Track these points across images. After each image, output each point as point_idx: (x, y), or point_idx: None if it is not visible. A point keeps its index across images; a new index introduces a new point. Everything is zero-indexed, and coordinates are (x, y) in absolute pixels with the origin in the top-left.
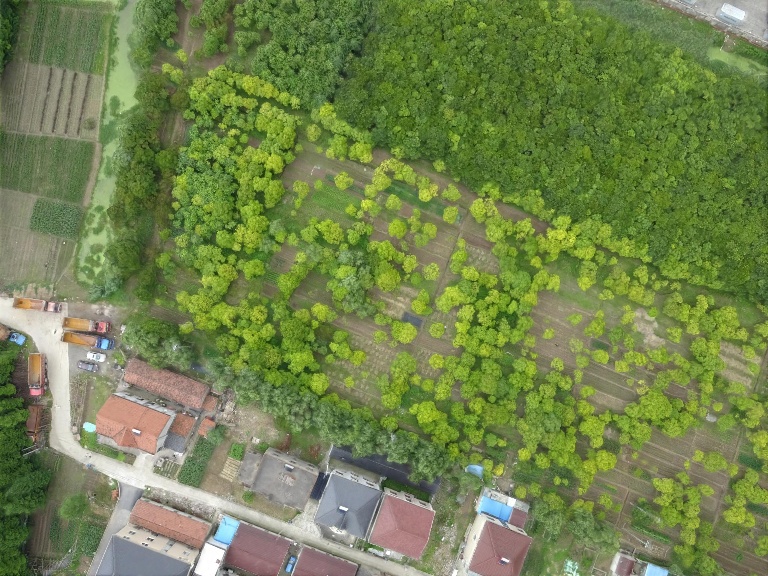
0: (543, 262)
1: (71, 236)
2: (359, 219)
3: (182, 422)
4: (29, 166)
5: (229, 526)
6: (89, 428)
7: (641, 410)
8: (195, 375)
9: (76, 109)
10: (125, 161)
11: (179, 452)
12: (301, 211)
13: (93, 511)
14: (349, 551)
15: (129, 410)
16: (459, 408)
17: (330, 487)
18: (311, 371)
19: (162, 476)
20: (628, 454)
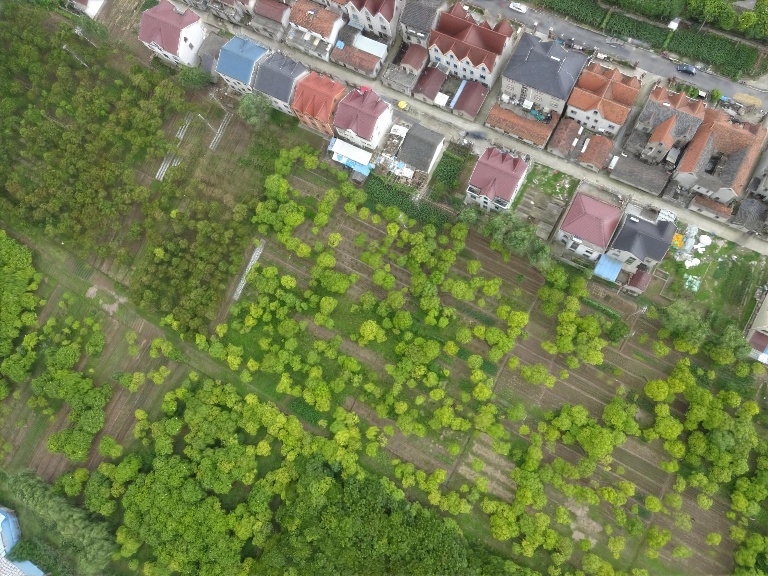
0: None
1: None
2: None
3: None
4: None
5: None
6: None
7: (614, 439)
8: None
9: None
10: None
11: None
12: None
13: None
14: None
15: None
16: None
17: None
18: None
19: None
20: None
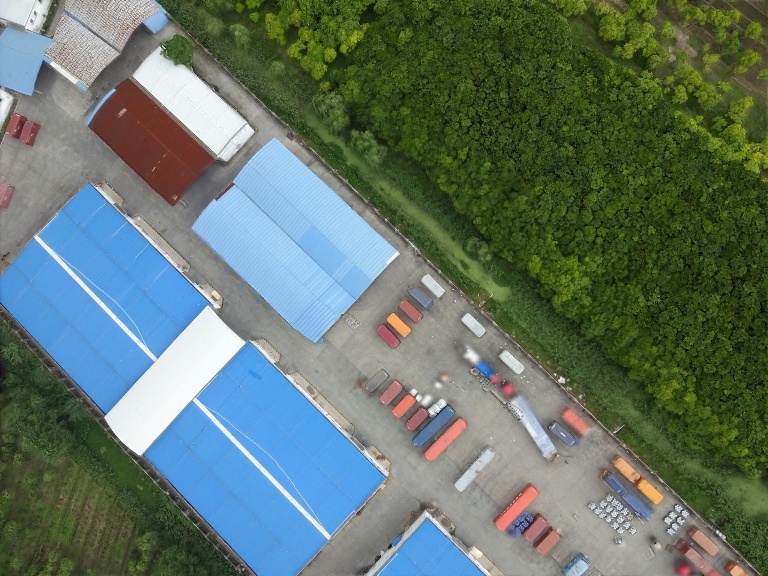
0: None
1: None
2: None
3: None
4: None
5: None
6: None
7: None
8: None
9: None
10: None
11: None
12: None
13: None
14: None
15: None
16: None
17: None
18: None
19: None
20: None
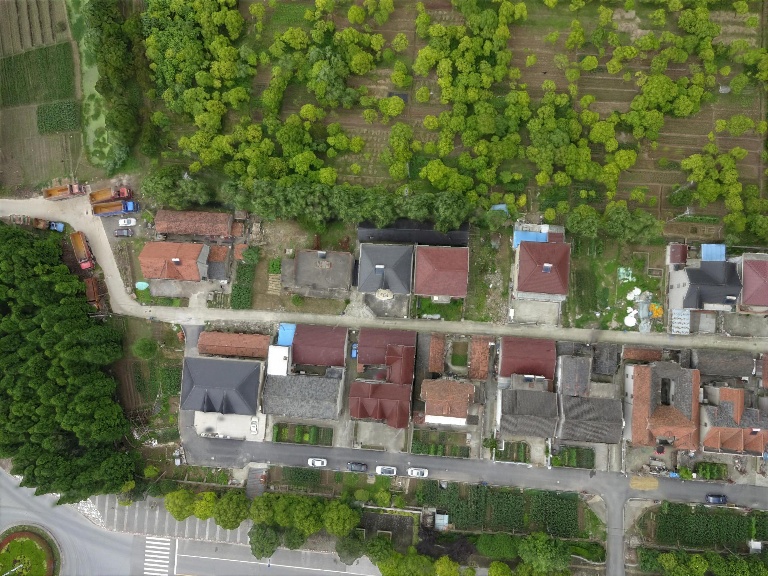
0: None
1: (75, 127)
2: (318, 19)
3: (217, 251)
4: (22, 81)
5: (288, 330)
6: (141, 287)
7: (646, 98)
8: (218, 212)
9: (45, 20)
10: (96, 37)
11: (223, 280)
12: (265, 36)
13: (167, 357)
14: (405, 323)
15: (166, 248)
16: (465, 155)
17: (363, 256)
18: (317, 168)
19: (217, 309)
20: (649, 151)
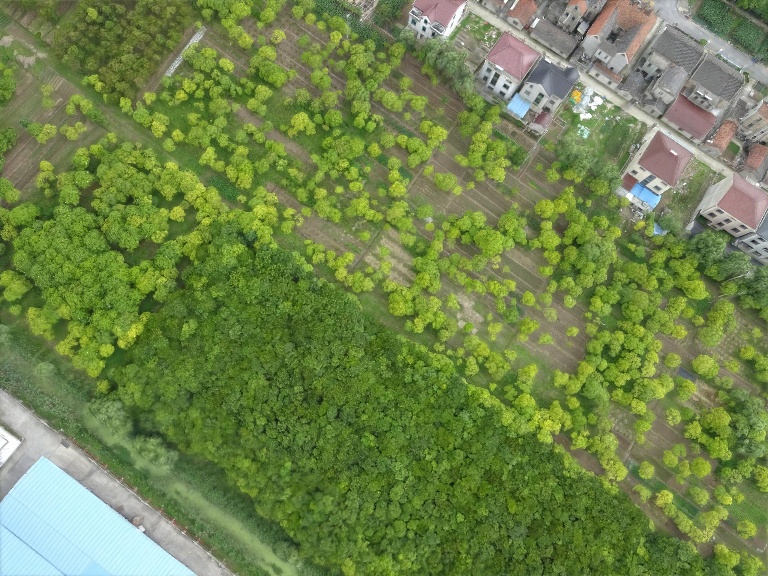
0: (561, 402)
1: None
2: None
3: None
4: None
5: None
6: None
7: (505, 242)
8: None
9: None
10: None
11: None
12: None
13: None
14: None
15: None
16: (669, 286)
17: None
18: None
19: None
20: None
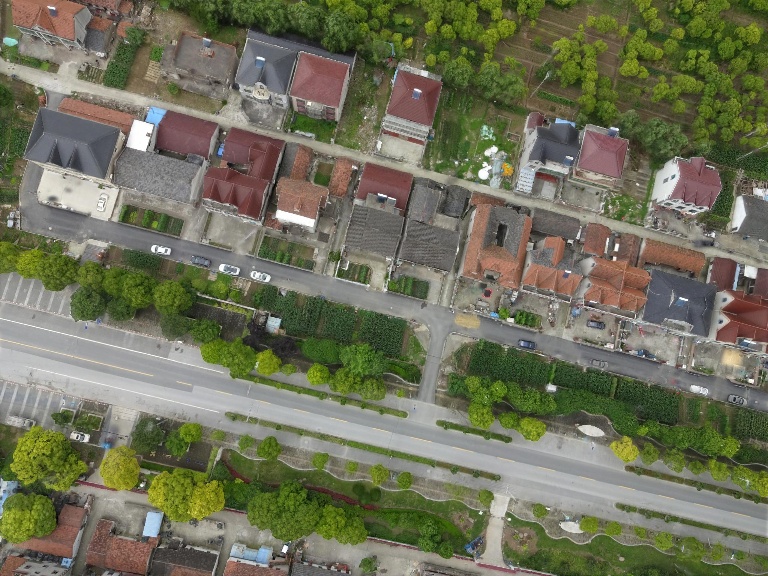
0: None
1: None
2: None
3: (100, 22)
4: None
5: (157, 114)
6: (9, 43)
7: None
8: None
9: None
10: None
11: (100, 52)
12: None
13: (22, 119)
14: (277, 135)
15: None
16: None
17: (247, 49)
18: None
19: (87, 82)
20: (529, 32)
